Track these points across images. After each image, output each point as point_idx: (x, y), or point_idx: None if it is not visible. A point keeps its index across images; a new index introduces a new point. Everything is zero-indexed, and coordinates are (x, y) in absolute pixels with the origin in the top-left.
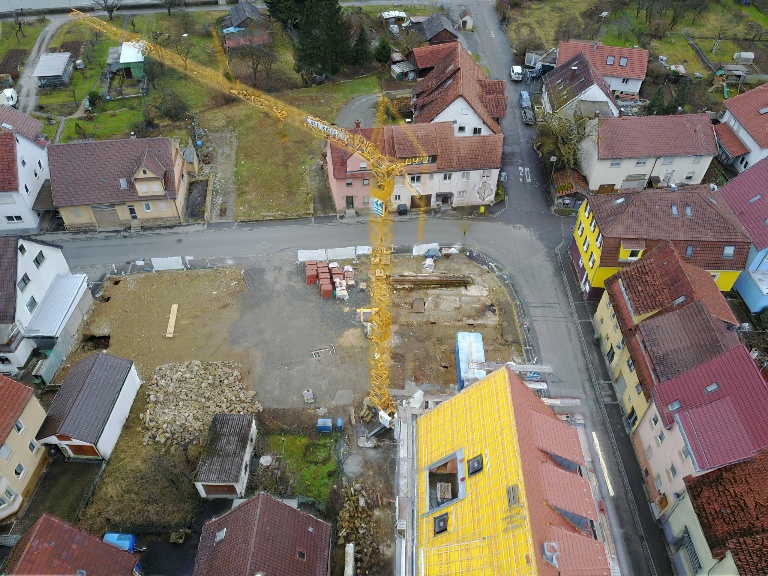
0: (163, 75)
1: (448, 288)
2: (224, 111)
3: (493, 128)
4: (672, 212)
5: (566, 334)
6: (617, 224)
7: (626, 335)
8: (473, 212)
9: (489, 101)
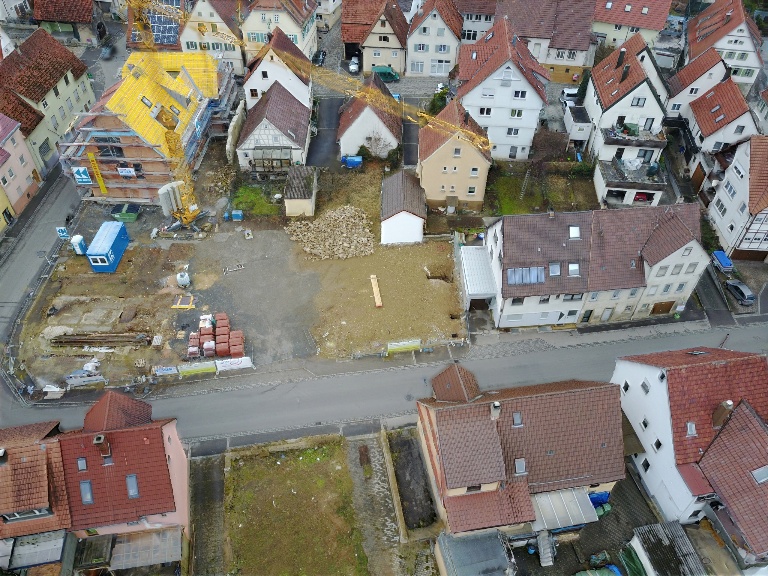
0: None
1: None
2: None
3: None
4: None
5: None
6: None
7: None
8: None
9: None
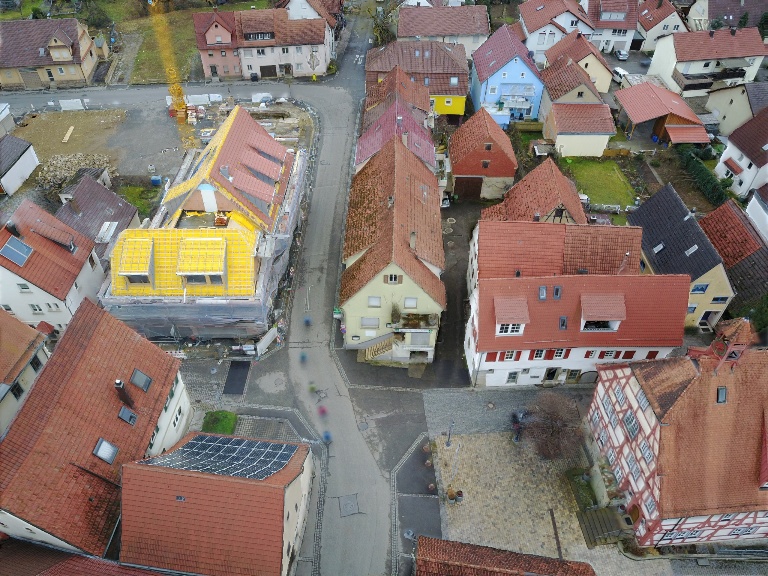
0: (96, 0)
1: (270, 119)
2: (138, 21)
3: (327, 19)
4: (415, 54)
5: (344, 142)
6: (376, 62)
7: (362, 124)
8: (308, 80)
9: (326, 0)
